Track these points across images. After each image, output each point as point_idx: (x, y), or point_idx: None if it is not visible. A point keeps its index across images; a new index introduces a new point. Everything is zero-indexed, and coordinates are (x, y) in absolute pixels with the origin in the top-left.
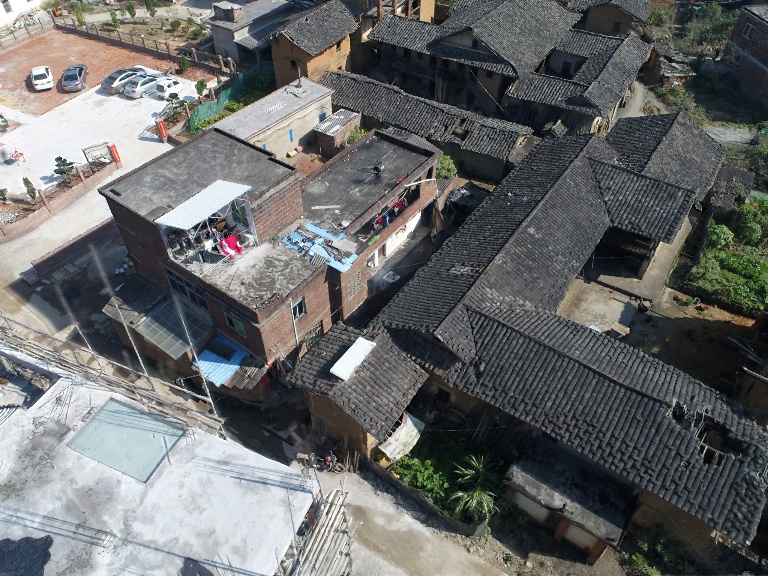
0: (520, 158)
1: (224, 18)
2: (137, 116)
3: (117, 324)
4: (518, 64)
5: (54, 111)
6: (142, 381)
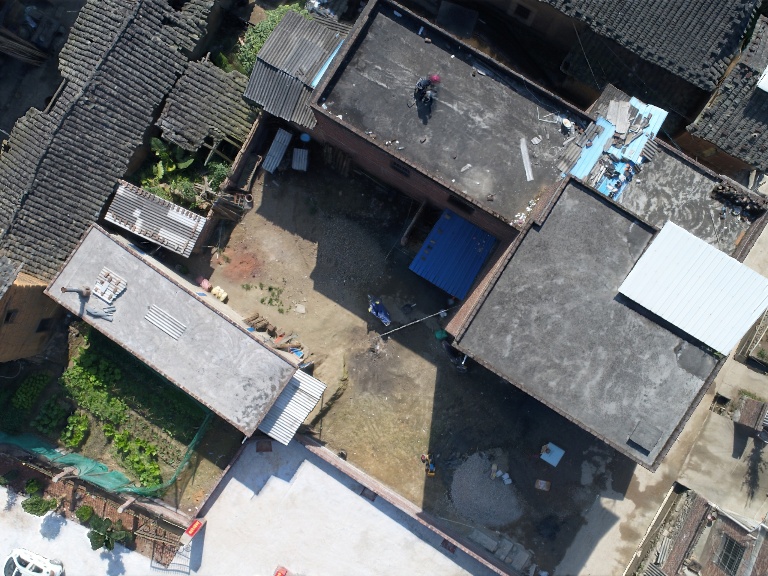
0: None
1: None
2: None
3: None
4: None
5: None
6: None
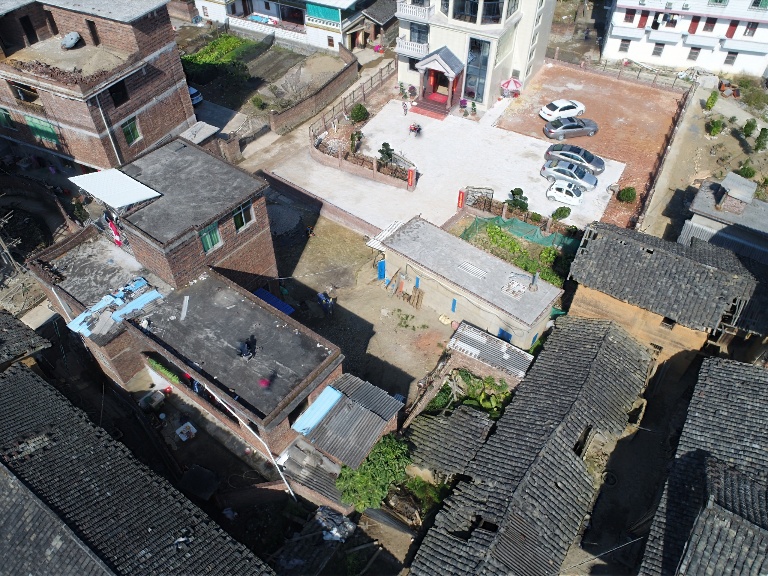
0: None
1: (719, 194)
2: (508, 184)
3: None
4: None
5: (505, 132)
6: None
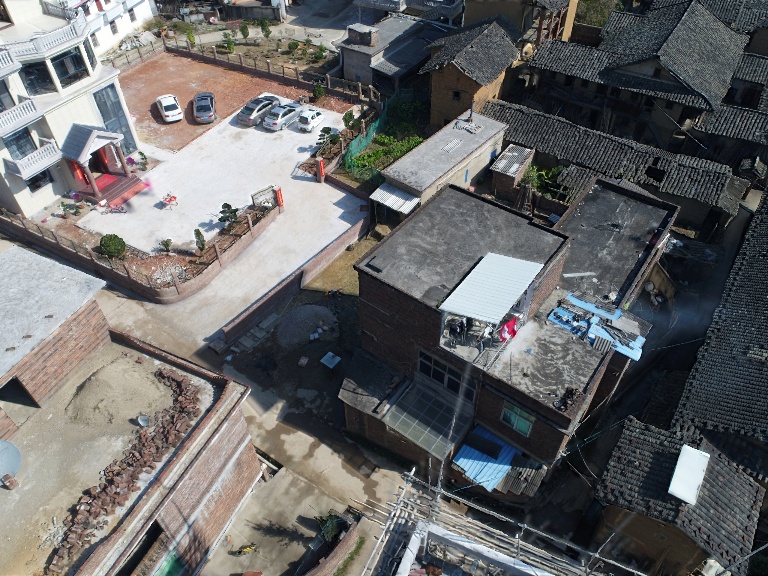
0: (727, 202)
1: (359, 42)
2: (282, 151)
3: (351, 410)
4: (709, 95)
5: (192, 146)
6: (378, 475)
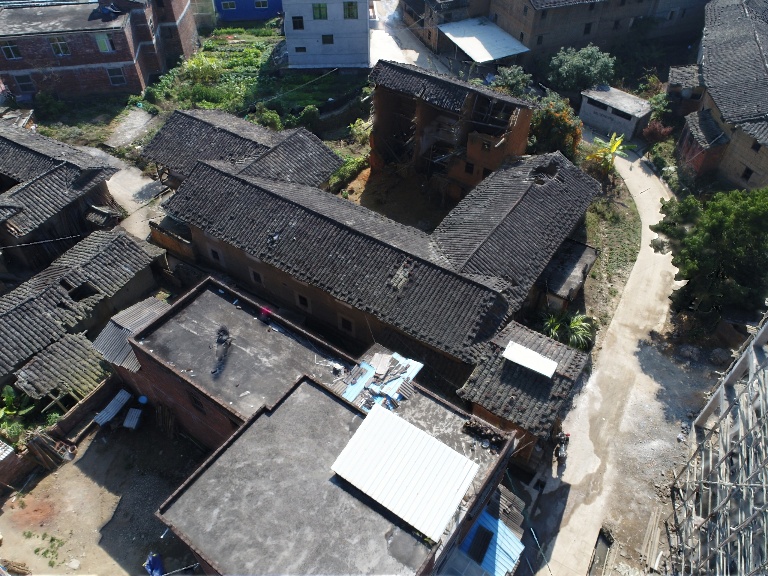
0: None
1: None
2: None
3: None
4: None
5: None
6: None
